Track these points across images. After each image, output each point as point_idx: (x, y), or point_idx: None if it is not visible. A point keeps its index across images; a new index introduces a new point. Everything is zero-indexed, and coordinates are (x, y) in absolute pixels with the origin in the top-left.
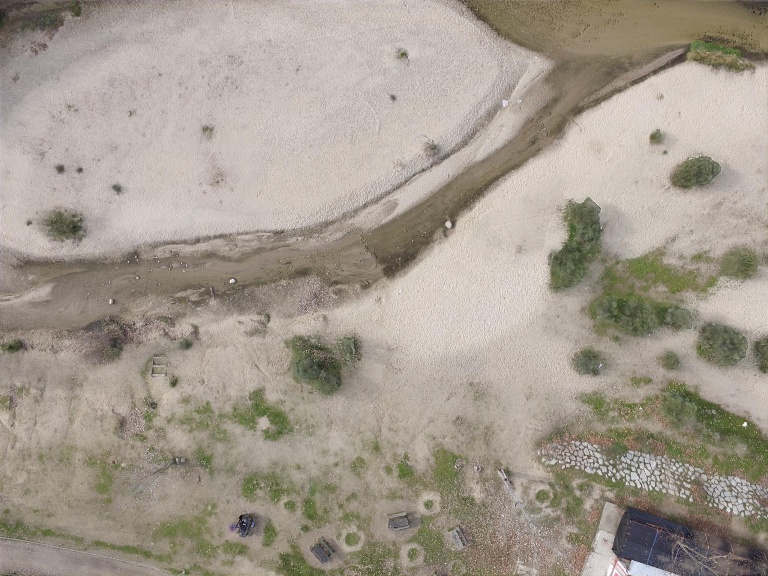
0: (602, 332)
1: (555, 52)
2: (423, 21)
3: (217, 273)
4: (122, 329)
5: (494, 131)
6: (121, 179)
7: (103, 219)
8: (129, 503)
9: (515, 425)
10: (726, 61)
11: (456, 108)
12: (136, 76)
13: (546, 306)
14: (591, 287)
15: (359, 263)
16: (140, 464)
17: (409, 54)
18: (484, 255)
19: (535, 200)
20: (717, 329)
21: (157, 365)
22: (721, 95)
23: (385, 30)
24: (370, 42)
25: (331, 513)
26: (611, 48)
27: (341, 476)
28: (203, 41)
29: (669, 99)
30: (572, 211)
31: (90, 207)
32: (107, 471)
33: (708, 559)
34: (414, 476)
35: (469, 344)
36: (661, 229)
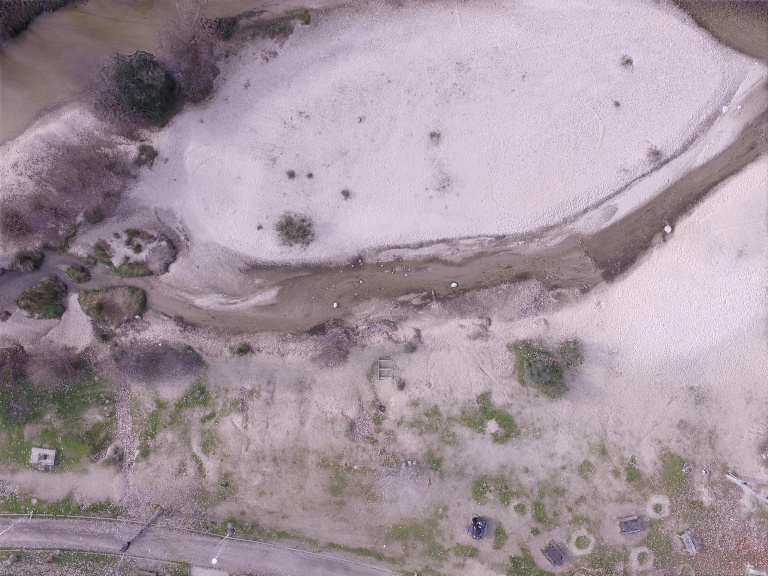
0: None
1: None
2: (647, 28)
3: (439, 277)
4: (346, 332)
5: (713, 136)
6: (350, 184)
7: (330, 224)
8: (362, 505)
9: (738, 429)
10: None
11: (679, 114)
12: (366, 83)
13: (766, 310)
14: None
15: (579, 267)
16: (372, 466)
17: (633, 61)
18: (705, 259)
19: (756, 205)
20: None
21: (383, 368)
22: None
23: (610, 37)
24: (595, 49)
25: (561, 516)
26: None
27: (569, 479)
28: (431, 48)
29: None
30: None
31: (319, 212)
32: (340, 473)
33: None
34: (642, 480)
35: (689, 348)
36: None
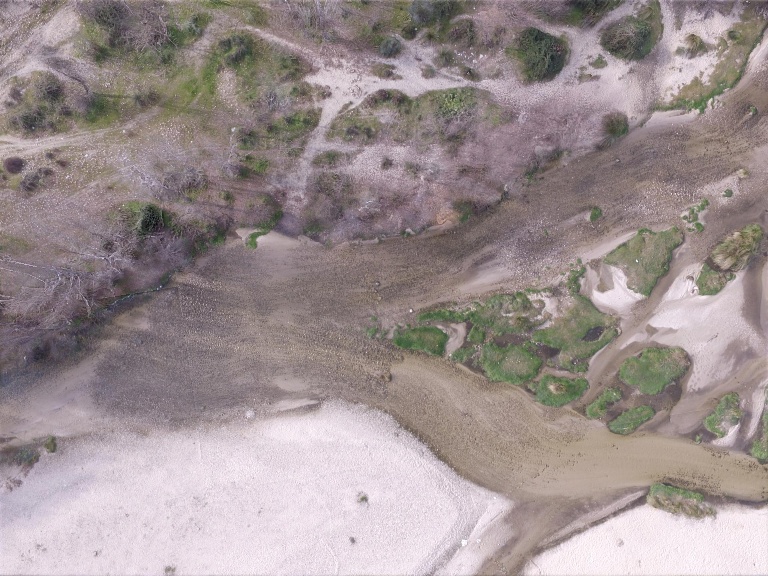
0: None
1: (514, 492)
2: (383, 464)
3: None
4: None
5: (453, 570)
6: None
7: None
8: None
9: None
10: (686, 510)
11: (415, 551)
12: (104, 516)
13: None
14: None
15: None
16: None
17: (369, 497)
18: None
19: None
20: None
21: None
22: (682, 543)
23: (346, 473)
24: (331, 485)
25: None
26: (570, 489)
27: None
28: (170, 482)
29: (629, 546)
30: None
31: None
32: None
33: None
34: None
35: None
36: None
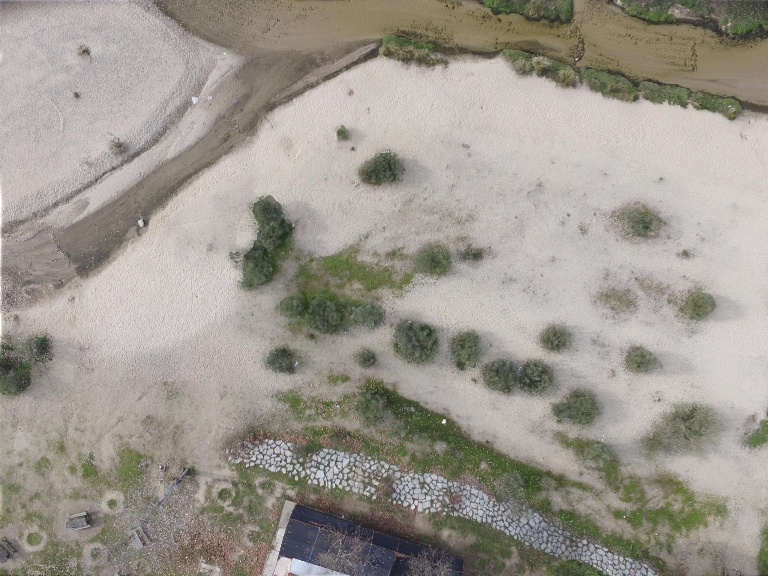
0: (297, 330)
1: (245, 48)
2: (105, 17)
3: None
4: None
5: (185, 128)
6: None
7: None
8: None
9: (207, 424)
10: (415, 56)
11: (142, 105)
12: None
13: (240, 304)
14: (285, 285)
15: (52, 262)
16: None
17: (91, 51)
18: (175, 254)
19: (225, 198)
20: (402, 326)
21: None
22: (411, 90)
23: (66, 27)
24: (51, 39)
25: (14, 513)
26: (302, 43)
27: (25, 476)
28: None
29: (359, 95)
30: None
31: None
32: None
33: (371, 557)
34: (98, 476)
35: (162, 343)
36: (353, 226)
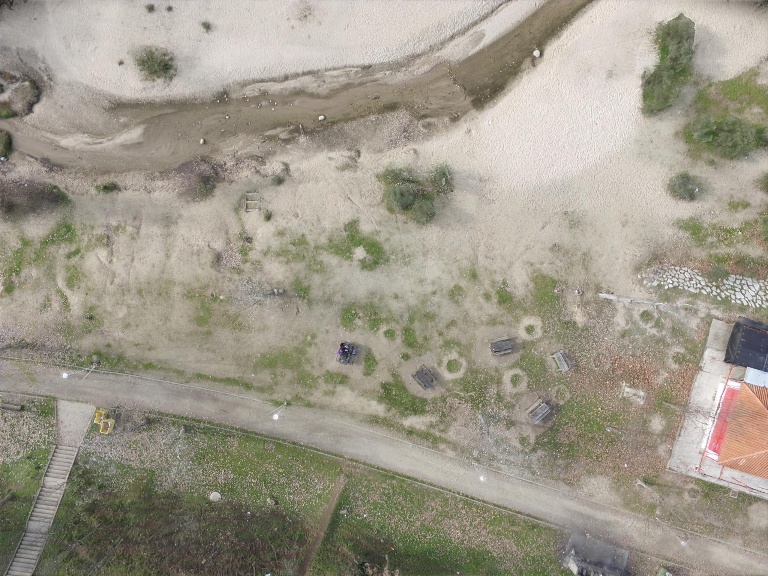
0: (697, 156)
1: None
2: None
3: (306, 110)
4: (213, 169)
5: None
6: (210, 16)
7: (193, 58)
8: (229, 335)
9: (613, 251)
10: None
11: None
12: None
13: (639, 131)
14: (684, 111)
15: (448, 96)
16: (238, 296)
17: None
18: (574, 81)
19: (624, 24)
20: None
21: (250, 201)
22: None
23: None
24: None
25: (431, 341)
26: None
27: (440, 304)
28: None
29: None
30: (665, 27)
31: (180, 45)
32: (206, 304)
33: None
34: (514, 302)
35: (562, 172)
36: (754, 48)
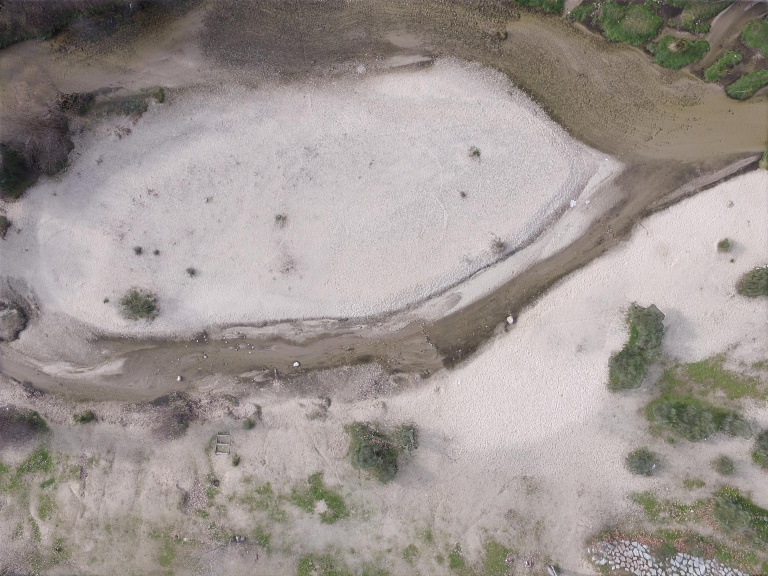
0: (657, 434)
1: (626, 155)
2: (496, 120)
3: (282, 356)
4: (188, 405)
5: (560, 230)
6: (195, 262)
7: (176, 300)
8: None
9: (566, 521)
10: None
11: (524, 207)
12: (214, 164)
13: (603, 405)
14: (649, 389)
15: (420, 353)
16: (201, 539)
17: (481, 152)
18: (544, 352)
19: (598, 301)
20: None
21: (221, 443)
22: None
23: (458, 128)
24: (443, 139)
25: None
26: (682, 153)
27: (394, 562)
28: (280, 132)
29: (739, 207)
30: (636, 317)
31: (164, 288)
32: (170, 544)
33: None
34: (465, 567)
35: (524, 438)
36: (723, 336)
